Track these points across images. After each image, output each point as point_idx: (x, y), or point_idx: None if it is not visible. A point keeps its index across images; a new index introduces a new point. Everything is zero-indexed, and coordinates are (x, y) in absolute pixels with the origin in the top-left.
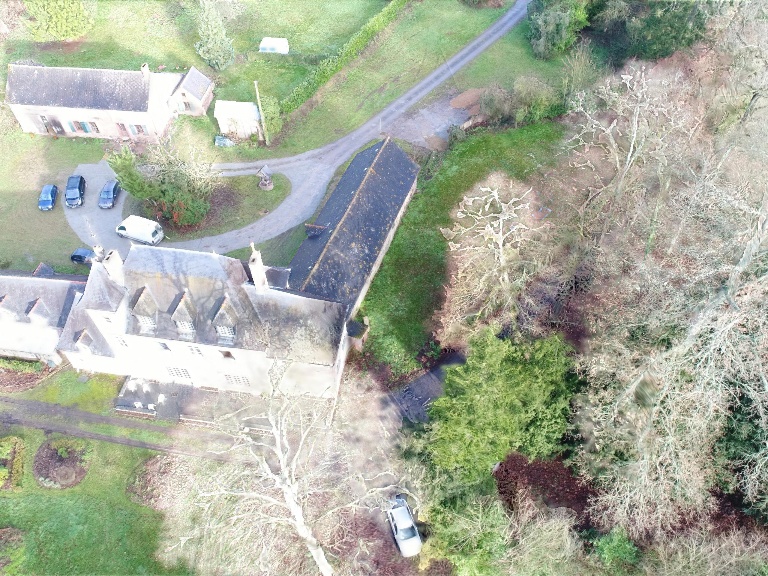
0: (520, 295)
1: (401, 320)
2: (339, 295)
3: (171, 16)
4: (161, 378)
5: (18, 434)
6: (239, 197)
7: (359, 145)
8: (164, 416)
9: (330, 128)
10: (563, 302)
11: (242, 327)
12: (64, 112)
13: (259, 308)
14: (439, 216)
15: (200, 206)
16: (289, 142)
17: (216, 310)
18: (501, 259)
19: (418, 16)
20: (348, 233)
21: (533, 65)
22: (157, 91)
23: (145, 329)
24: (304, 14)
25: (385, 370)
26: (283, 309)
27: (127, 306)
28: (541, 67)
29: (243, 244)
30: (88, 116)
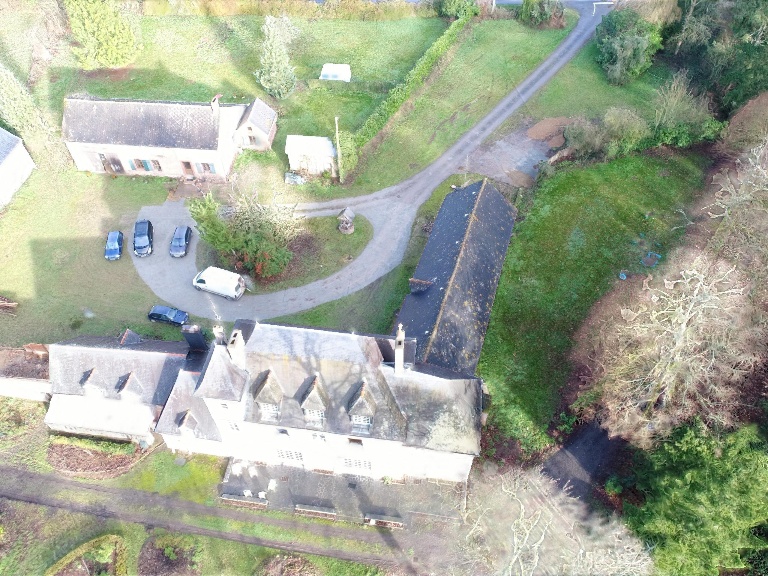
0: (706, 382)
1: (522, 386)
2: (459, 362)
3: (220, 39)
4: (269, 460)
5: (116, 530)
6: (319, 242)
7: (438, 181)
8: (277, 506)
9: (404, 162)
10: (737, 382)
11: (380, 415)
12: (125, 150)
13: (397, 392)
14: (540, 263)
15: (283, 255)
16: (363, 178)
17: (351, 396)
18: (679, 339)
19: (478, 38)
20: (460, 290)
21: (608, 91)
22: (225, 126)
23: (266, 416)
24: (360, 37)
25: (515, 447)
26: (425, 393)
27: (247, 391)
28: (617, 94)
29: (331, 296)
30: (151, 154)
